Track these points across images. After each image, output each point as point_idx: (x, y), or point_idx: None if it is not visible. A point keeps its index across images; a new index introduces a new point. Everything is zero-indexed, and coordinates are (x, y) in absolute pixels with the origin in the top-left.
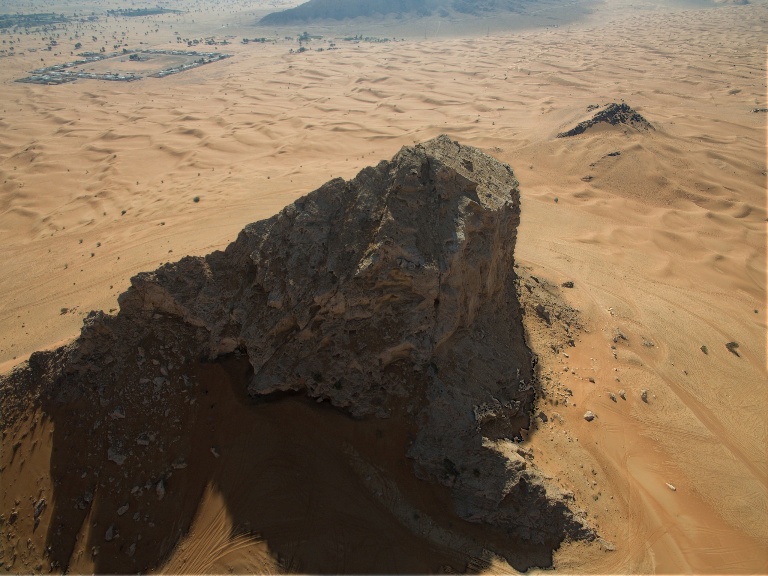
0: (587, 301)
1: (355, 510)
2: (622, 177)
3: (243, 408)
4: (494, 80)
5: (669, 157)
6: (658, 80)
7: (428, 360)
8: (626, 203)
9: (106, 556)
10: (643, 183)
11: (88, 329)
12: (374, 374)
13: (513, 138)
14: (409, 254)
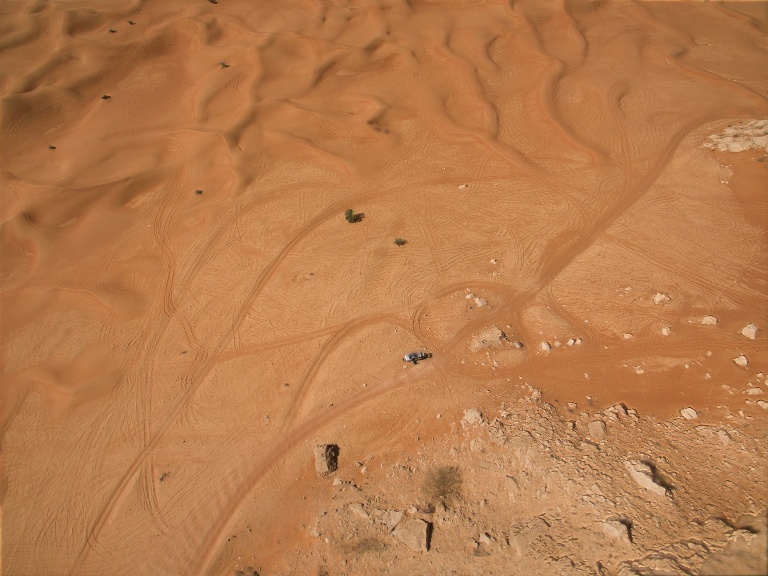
0: (407, 405)
1: None
2: None
3: None
4: None
5: None
6: None
7: None
8: None
9: None
10: None
11: None
12: None
13: None
14: None
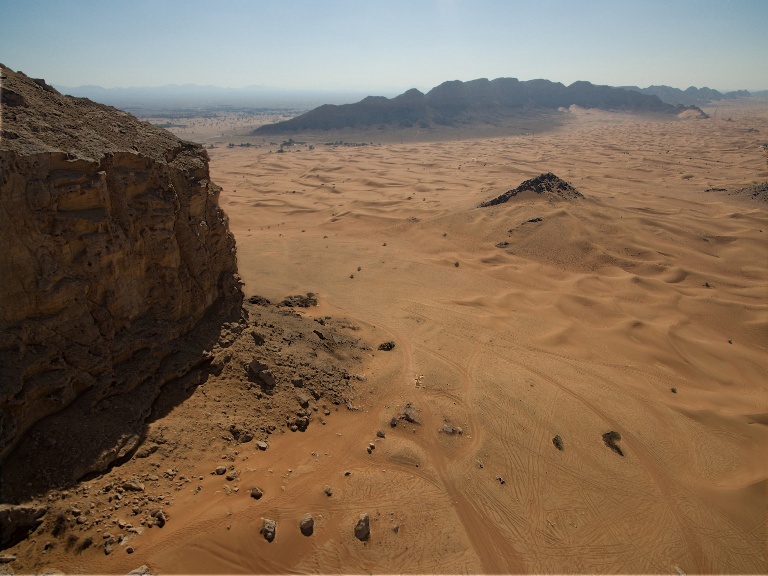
0: (391, 366)
1: None
2: (542, 243)
3: None
4: (447, 169)
5: (597, 223)
6: (612, 169)
7: None
8: (540, 268)
9: None
10: (565, 249)
11: None
12: None
13: (434, 209)
14: None
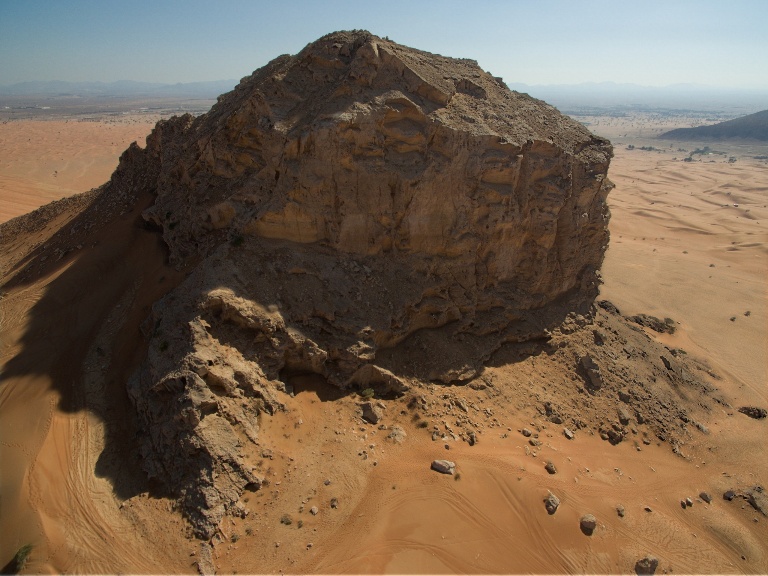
0: (750, 435)
1: (84, 318)
2: None
3: (131, 225)
4: None
5: None
6: None
7: (240, 232)
8: None
9: (16, 279)
10: None
11: (125, 151)
12: (194, 224)
13: None
14: (273, 114)
